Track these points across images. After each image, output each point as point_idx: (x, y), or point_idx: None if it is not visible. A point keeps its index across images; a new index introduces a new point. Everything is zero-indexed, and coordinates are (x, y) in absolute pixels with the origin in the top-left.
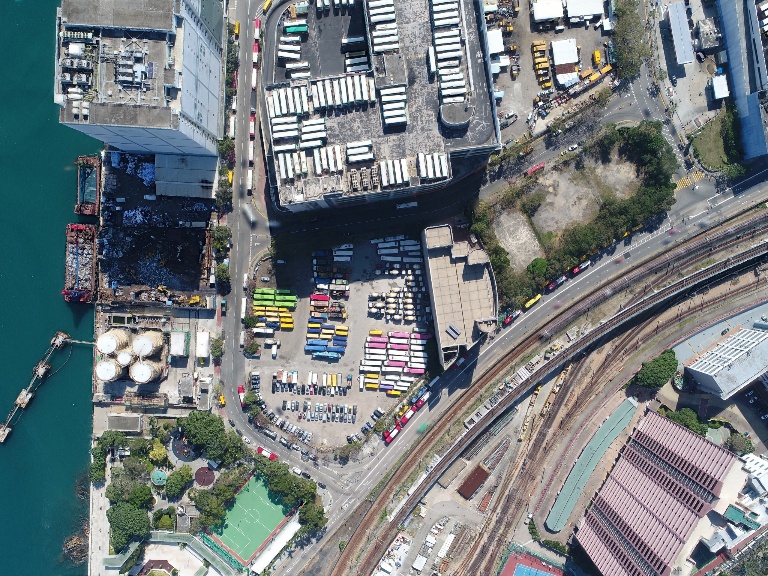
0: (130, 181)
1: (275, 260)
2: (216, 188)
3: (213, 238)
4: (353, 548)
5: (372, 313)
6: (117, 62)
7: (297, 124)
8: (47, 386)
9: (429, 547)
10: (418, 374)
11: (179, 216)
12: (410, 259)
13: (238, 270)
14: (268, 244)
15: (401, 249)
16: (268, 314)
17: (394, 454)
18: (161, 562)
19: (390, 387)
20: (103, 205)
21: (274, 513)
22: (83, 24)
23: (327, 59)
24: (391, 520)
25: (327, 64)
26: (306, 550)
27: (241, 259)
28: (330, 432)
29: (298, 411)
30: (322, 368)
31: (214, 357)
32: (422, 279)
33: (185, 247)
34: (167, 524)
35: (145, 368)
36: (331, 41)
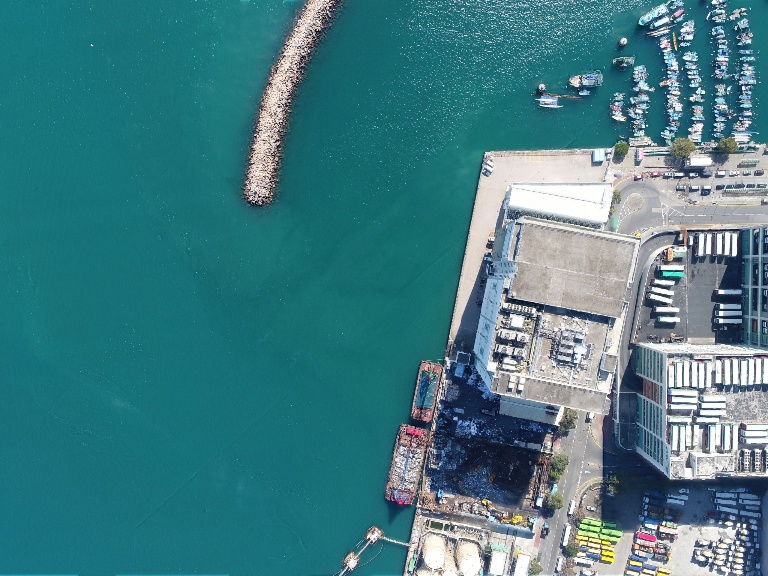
0: (469, 392)
1: (604, 491)
2: (561, 416)
3: (551, 465)
4: None
5: (697, 560)
6: (556, 340)
7: (697, 399)
8: None
9: None
10: None
11: (513, 433)
12: (748, 513)
13: (564, 495)
14: (599, 474)
15: (740, 502)
16: (590, 545)
17: None
18: None
19: None
20: (439, 412)
21: None
22: (531, 301)
23: (696, 305)
24: None
25: (695, 310)
26: None
27: (569, 484)
28: None
29: None
30: None
31: None
32: (757, 535)
33: (518, 467)
34: None
35: None
36: (703, 287)
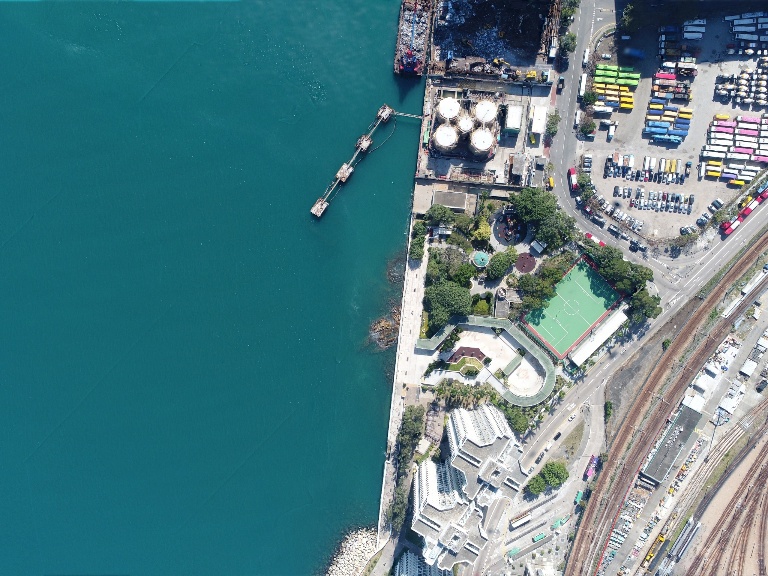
0: None
1: (618, 36)
2: None
3: (562, 5)
4: (677, 348)
5: (719, 96)
6: None
7: None
8: (366, 162)
9: (761, 351)
10: (763, 164)
11: None
12: (767, 38)
13: (578, 46)
14: (612, 19)
15: (759, 27)
16: (608, 92)
17: (730, 250)
18: (473, 350)
19: (734, 176)
20: None
21: (595, 306)
22: None
23: None
24: (727, 316)
25: None
26: (626, 347)
27: (582, 34)
28: (662, 223)
29: (630, 198)
30: (659, 154)
31: (546, 137)
32: None
33: (528, 17)
34: (483, 310)
35: (487, 135)
36: None
